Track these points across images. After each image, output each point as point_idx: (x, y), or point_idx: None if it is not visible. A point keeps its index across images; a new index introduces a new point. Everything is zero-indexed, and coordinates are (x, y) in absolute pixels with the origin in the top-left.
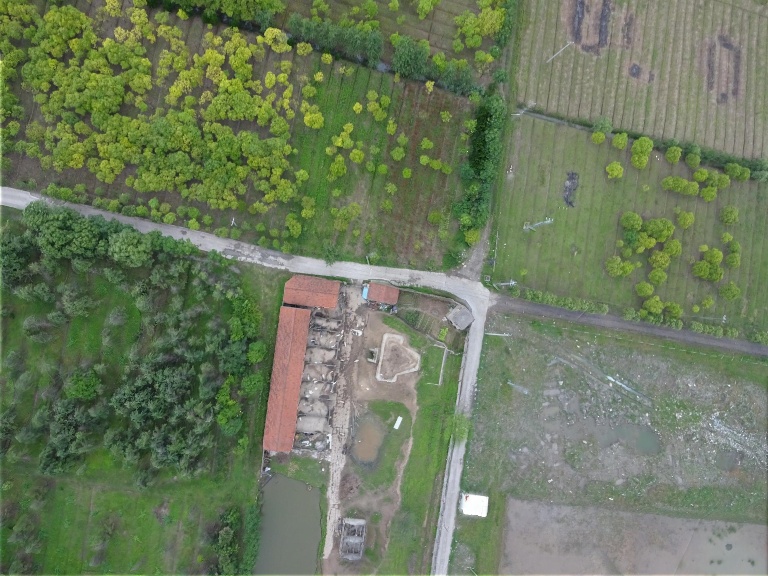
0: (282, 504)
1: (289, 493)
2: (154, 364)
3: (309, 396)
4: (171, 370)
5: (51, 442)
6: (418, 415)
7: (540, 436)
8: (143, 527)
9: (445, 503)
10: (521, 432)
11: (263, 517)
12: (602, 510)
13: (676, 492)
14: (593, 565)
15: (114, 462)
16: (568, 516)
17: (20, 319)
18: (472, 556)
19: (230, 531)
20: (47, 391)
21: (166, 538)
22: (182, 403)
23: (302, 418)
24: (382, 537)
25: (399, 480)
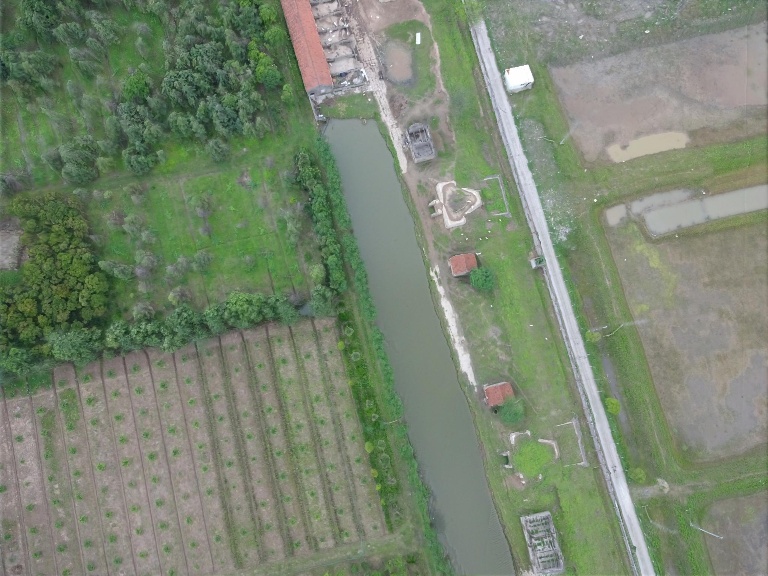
0: (347, 144)
1: (350, 137)
2: (185, 47)
3: (330, 43)
4: (201, 44)
5: (129, 146)
6: (432, 23)
7: (552, 1)
8: (234, 198)
9: (492, 89)
10: (533, 5)
11: (331, 144)
12: (645, 50)
13: (707, 2)
14: (661, 100)
15: (188, 152)
16: (615, 66)
17: (68, 67)
18: (539, 126)
19: (305, 154)
20: (109, 102)
21: (257, 201)
22: (221, 68)
23: (332, 64)
24: (447, 136)
25: (440, 80)
